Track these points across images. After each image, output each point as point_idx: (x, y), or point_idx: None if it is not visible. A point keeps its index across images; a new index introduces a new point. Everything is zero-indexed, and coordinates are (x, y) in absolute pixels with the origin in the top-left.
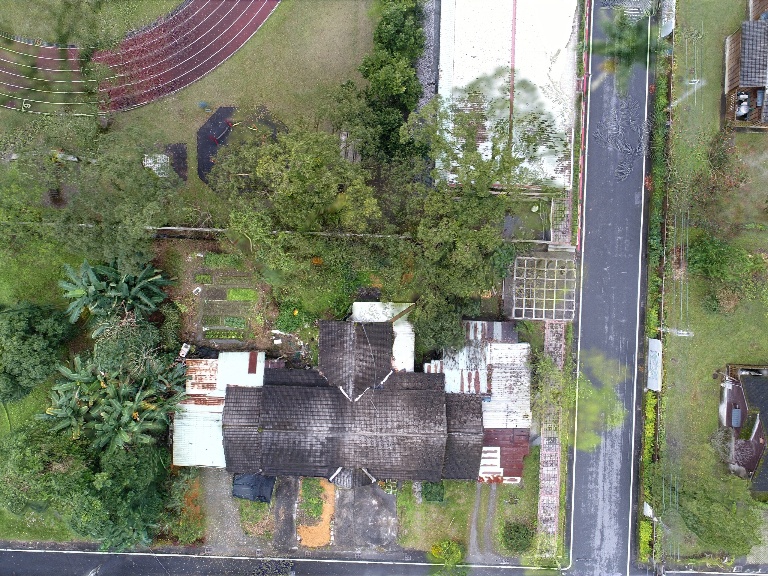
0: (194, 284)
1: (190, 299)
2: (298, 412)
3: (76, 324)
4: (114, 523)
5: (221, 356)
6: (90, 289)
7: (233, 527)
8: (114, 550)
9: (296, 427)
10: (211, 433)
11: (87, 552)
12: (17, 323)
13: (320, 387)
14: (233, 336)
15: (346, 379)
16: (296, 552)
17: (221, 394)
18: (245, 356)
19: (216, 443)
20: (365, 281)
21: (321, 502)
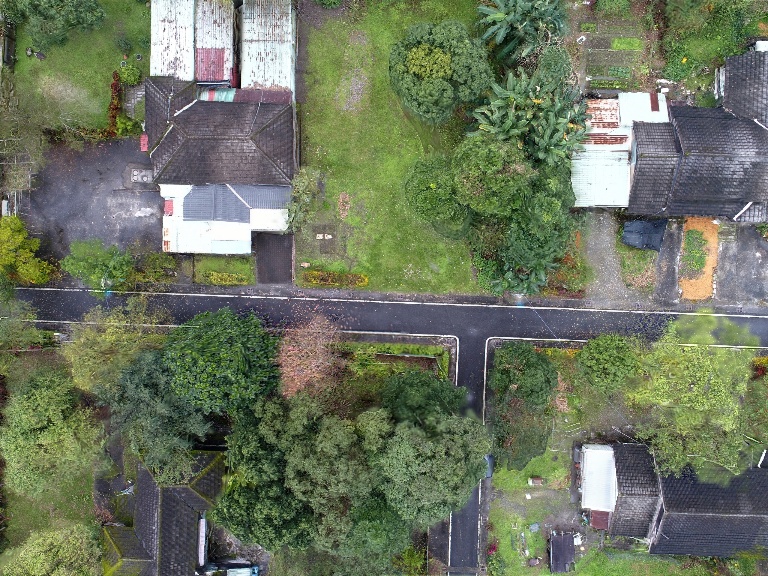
0: (579, 33)
1: (574, 48)
2: (720, 139)
3: (500, 46)
4: (558, 234)
5: (621, 95)
6: (518, 8)
7: (614, 280)
8: (493, 303)
9: (722, 151)
10: (612, 172)
11: (465, 305)
12: (462, 30)
13: (734, 119)
14: (617, 86)
15: (762, 110)
16: (677, 306)
17: (624, 132)
18: (646, 95)
19: (618, 182)
20: (754, 29)
21: (703, 255)
